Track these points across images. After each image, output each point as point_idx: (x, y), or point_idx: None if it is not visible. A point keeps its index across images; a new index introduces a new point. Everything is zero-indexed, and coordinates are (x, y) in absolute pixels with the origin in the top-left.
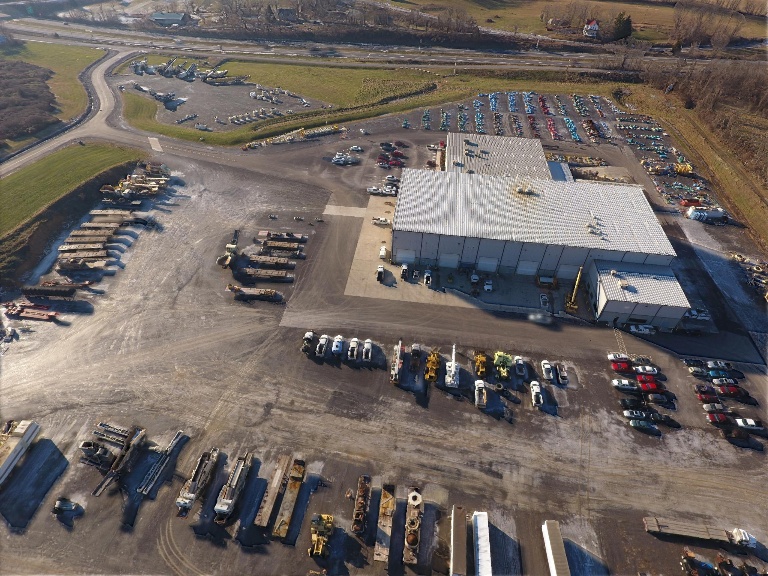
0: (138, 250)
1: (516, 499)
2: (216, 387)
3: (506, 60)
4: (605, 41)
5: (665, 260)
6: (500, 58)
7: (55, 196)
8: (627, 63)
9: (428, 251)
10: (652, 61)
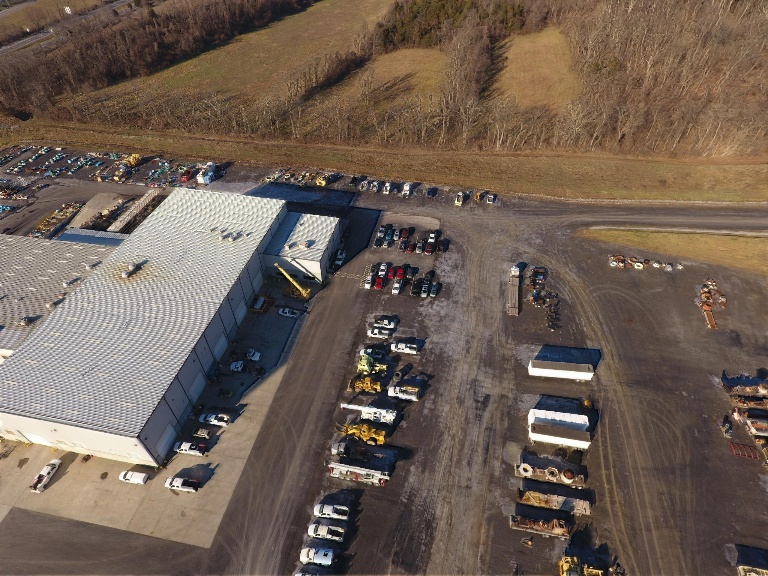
0: None
1: (507, 389)
2: None
3: None
4: None
5: (284, 210)
6: None
7: None
8: None
9: (179, 405)
10: None
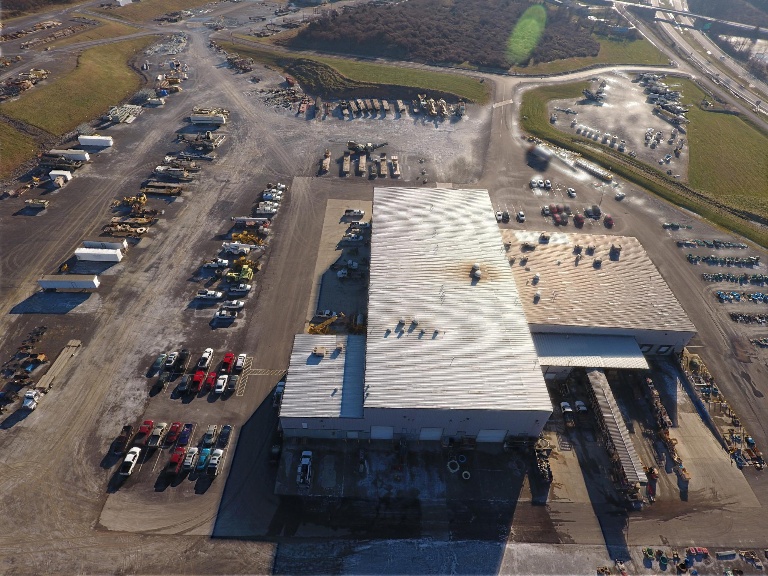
0: (366, 122)
1: (127, 277)
2: (245, 163)
3: None
4: None
5: None
6: None
7: (404, 84)
8: None
9: None
10: None
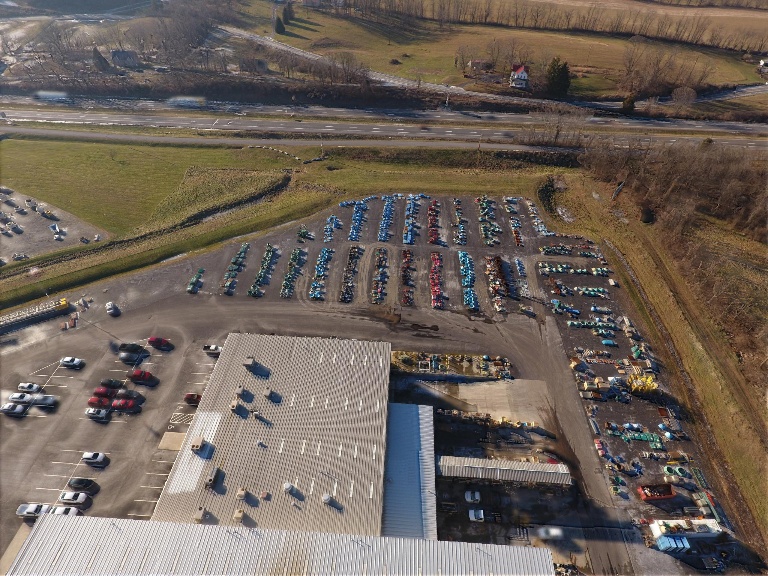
0: None
1: None
2: None
3: (402, 128)
4: (537, 94)
5: None
6: (395, 124)
7: None
8: (561, 137)
9: None
10: (595, 134)
